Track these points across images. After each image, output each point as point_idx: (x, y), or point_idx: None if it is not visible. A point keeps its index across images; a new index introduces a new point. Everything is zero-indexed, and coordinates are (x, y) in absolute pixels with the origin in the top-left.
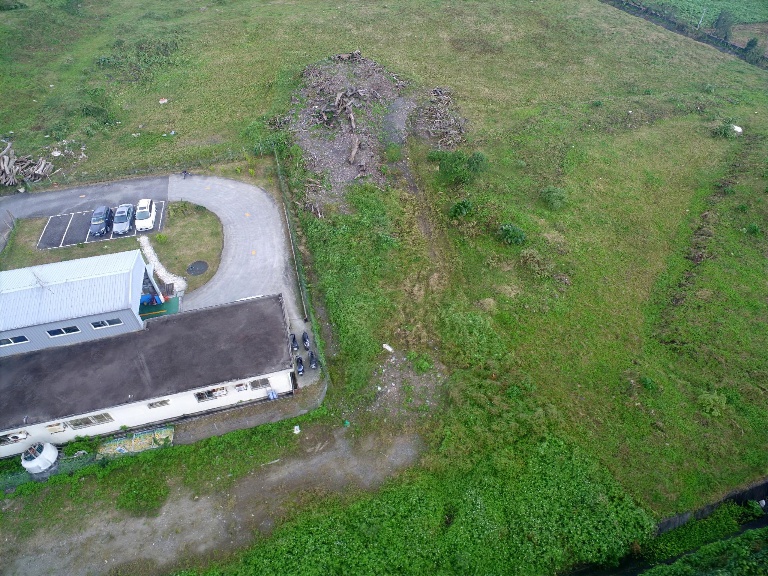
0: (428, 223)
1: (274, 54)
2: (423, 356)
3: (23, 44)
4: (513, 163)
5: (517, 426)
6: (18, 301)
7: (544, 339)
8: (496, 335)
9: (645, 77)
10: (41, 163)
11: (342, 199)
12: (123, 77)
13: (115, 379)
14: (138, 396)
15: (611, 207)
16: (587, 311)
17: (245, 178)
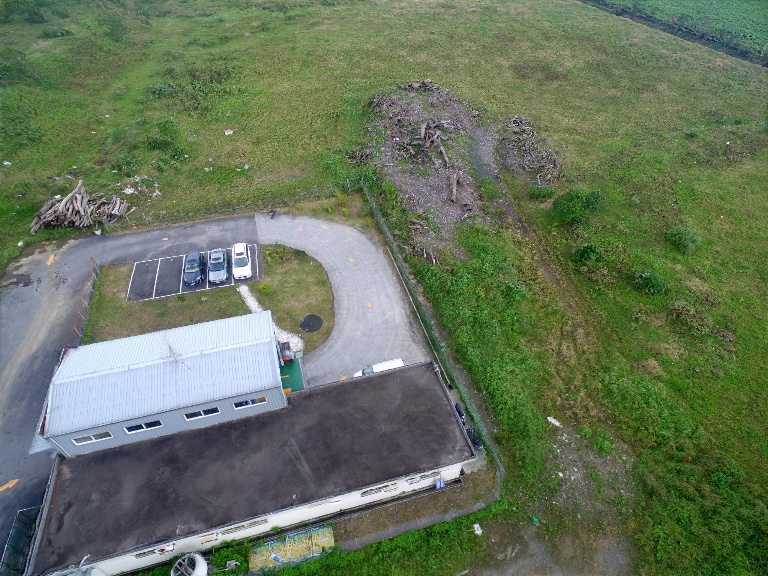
0: (551, 269)
1: (332, 82)
2: (600, 433)
3: (73, 72)
4: (623, 200)
5: (741, 525)
6: (150, 378)
7: (729, 410)
8: (676, 406)
9: (727, 105)
10: (116, 202)
11: (454, 242)
12: (181, 107)
13: (269, 473)
14: (302, 496)
15: (746, 250)
16: (766, 375)
17: (338, 218)
